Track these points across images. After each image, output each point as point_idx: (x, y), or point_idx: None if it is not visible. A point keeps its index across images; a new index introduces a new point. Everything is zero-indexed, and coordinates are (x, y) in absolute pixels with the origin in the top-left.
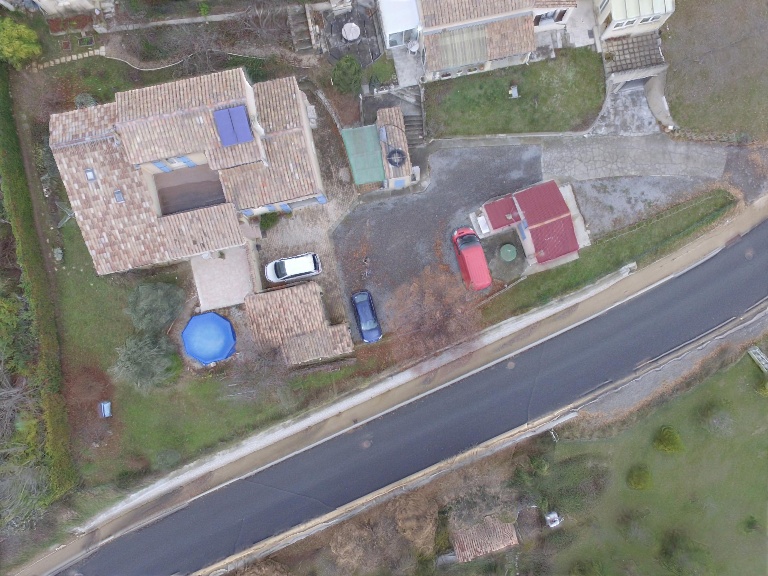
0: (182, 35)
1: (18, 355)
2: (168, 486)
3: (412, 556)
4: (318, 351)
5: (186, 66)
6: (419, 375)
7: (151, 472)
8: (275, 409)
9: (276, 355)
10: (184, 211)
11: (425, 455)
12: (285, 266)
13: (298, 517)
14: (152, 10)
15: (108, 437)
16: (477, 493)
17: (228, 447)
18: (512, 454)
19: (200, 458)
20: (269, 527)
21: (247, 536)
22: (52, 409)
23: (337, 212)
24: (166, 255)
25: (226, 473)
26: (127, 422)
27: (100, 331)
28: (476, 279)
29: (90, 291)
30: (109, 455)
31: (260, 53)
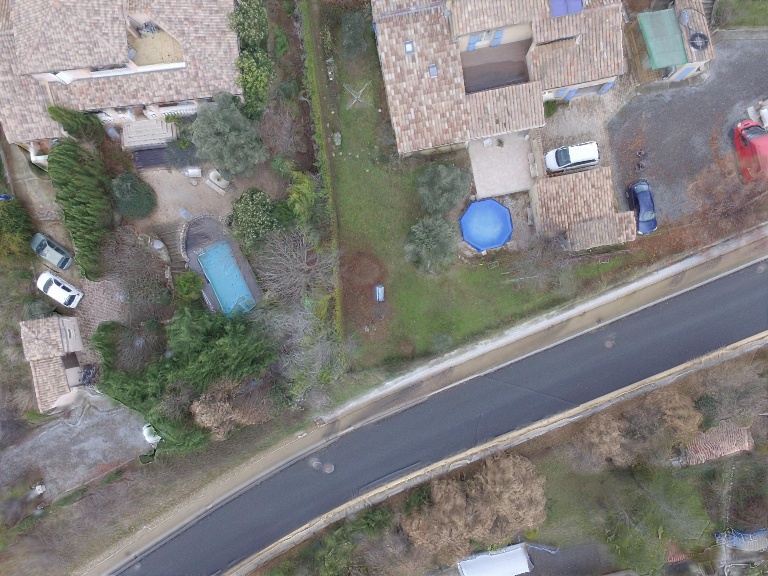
0: None
1: (314, 232)
2: (419, 377)
3: (669, 448)
4: (602, 238)
5: None
6: (667, 277)
7: (419, 357)
8: (541, 300)
9: (548, 245)
10: (493, 88)
11: (667, 357)
12: (569, 153)
13: (540, 413)
14: None
15: (379, 322)
16: (713, 397)
17: (490, 337)
18: (752, 359)
19: (461, 347)
20: (509, 422)
21: (485, 431)
22: (340, 287)
23: (613, 103)
24: (467, 134)
25: (466, 369)
26: (397, 308)
27: (375, 217)
28: (767, 169)
29: (366, 177)
30: (377, 340)
31: None
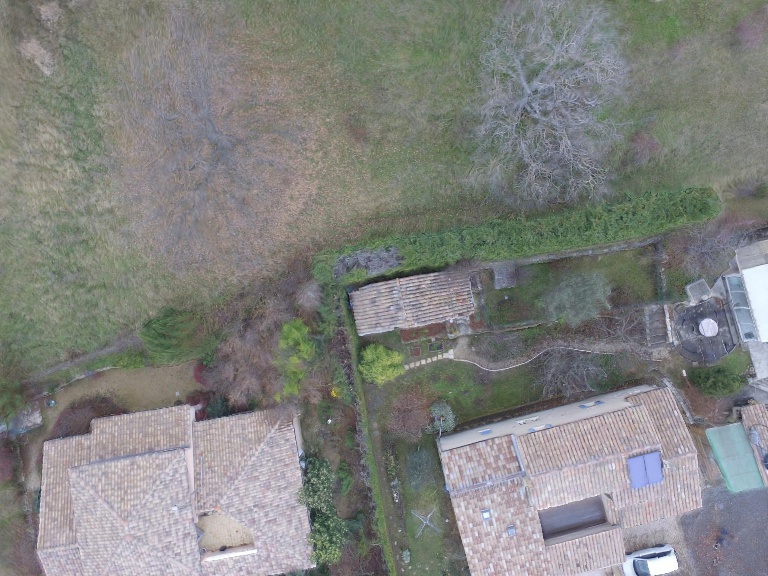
0: (531, 334)
1: None
2: None
3: None
4: None
5: (568, 390)
6: None
7: None
8: None
9: None
10: (573, 539)
11: None
12: (648, 566)
13: None
14: (512, 320)
15: None
16: None
17: None
18: None
19: None
20: None
21: None
22: None
23: None
24: None
25: None
26: None
27: None
28: None
29: None
30: None
31: (610, 348)
